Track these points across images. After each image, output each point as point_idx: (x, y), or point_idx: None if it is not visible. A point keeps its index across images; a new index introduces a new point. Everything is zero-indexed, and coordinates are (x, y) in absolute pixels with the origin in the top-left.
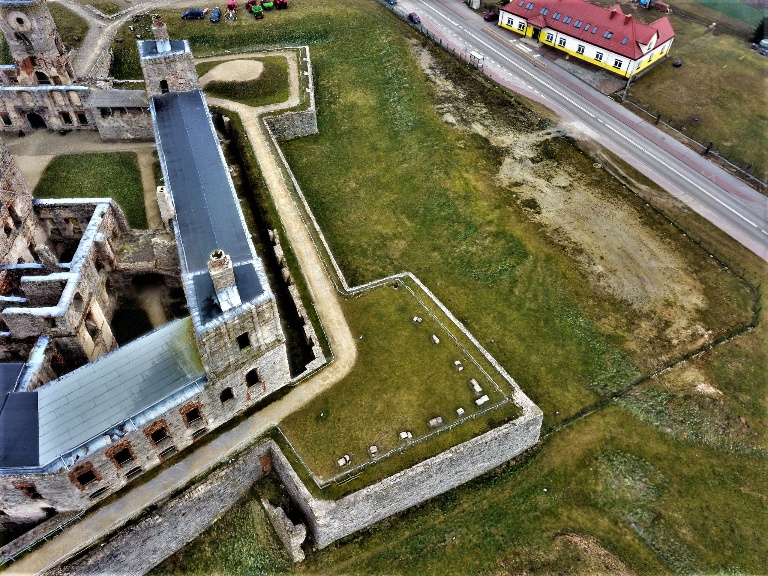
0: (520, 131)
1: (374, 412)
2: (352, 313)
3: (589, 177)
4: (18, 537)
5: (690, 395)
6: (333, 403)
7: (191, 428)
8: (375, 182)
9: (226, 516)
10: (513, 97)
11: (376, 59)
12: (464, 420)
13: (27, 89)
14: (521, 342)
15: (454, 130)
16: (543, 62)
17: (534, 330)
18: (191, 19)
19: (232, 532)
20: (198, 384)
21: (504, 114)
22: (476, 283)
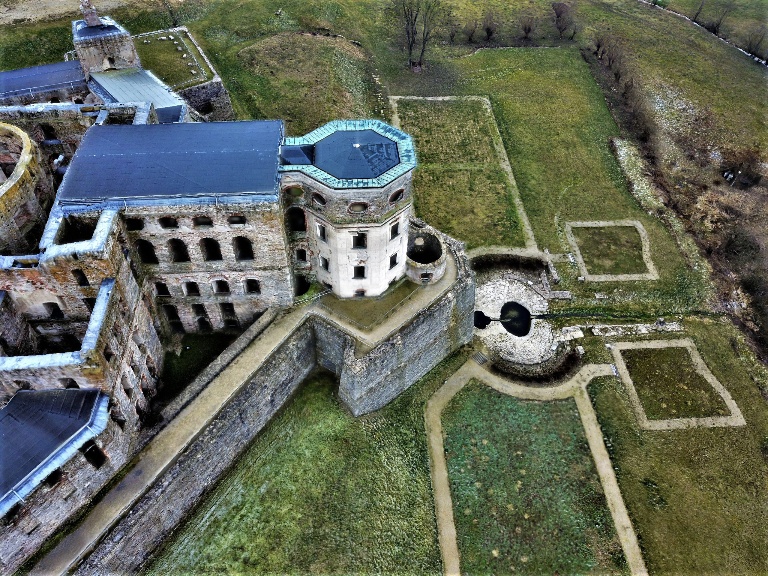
0: None
1: (167, 65)
2: None
3: (5, 1)
4: None
5: (184, 4)
6: None
7: None
8: None
9: None
10: None
11: None
12: None
13: None
14: None
15: None
16: None
17: None
18: None
19: None
20: (144, 71)
21: None
22: None
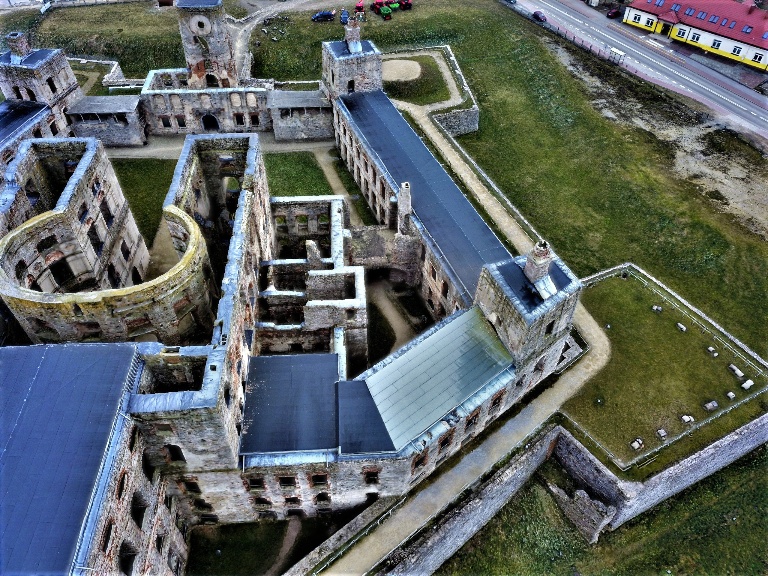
0: (681, 125)
1: (648, 397)
2: (591, 303)
3: (763, 168)
4: (350, 521)
5: None
6: (605, 389)
7: (489, 415)
8: (550, 177)
9: (513, 500)
10: (663, 92)
11: (512, 57)
12: (740, 403)
13: (208, 91)
14: (745, 329)
15: (617, 125)
16: (681, 57)
17: (755, 317)
18: (321, 21)
19: (522, 516)
20: (510, 371)
21: (660, 109)
22: (684, 273)
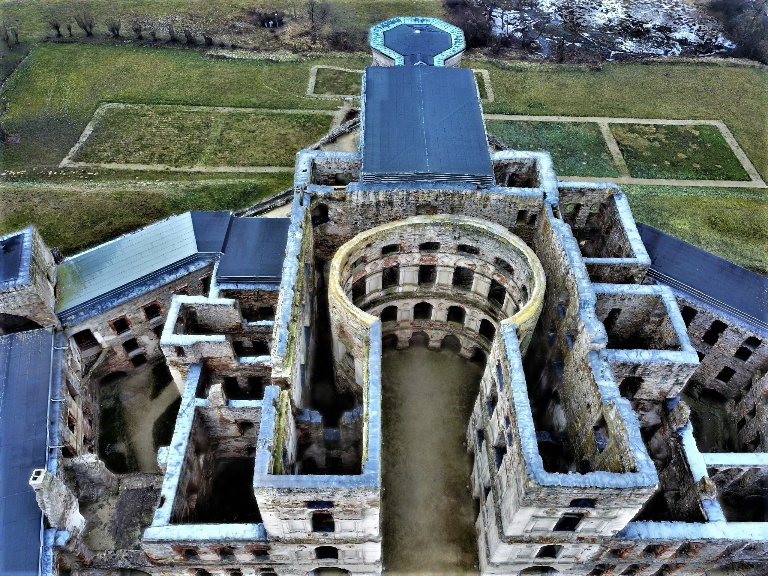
0: None
1: None
2: None
3: None
4: None
5: None
6: None
7: None
8: None
9: None
10: None
11: None
12: None
13: None
14: None
15: None
16: None
17: None
18: None
19: None
20: None
21: None
22: None
